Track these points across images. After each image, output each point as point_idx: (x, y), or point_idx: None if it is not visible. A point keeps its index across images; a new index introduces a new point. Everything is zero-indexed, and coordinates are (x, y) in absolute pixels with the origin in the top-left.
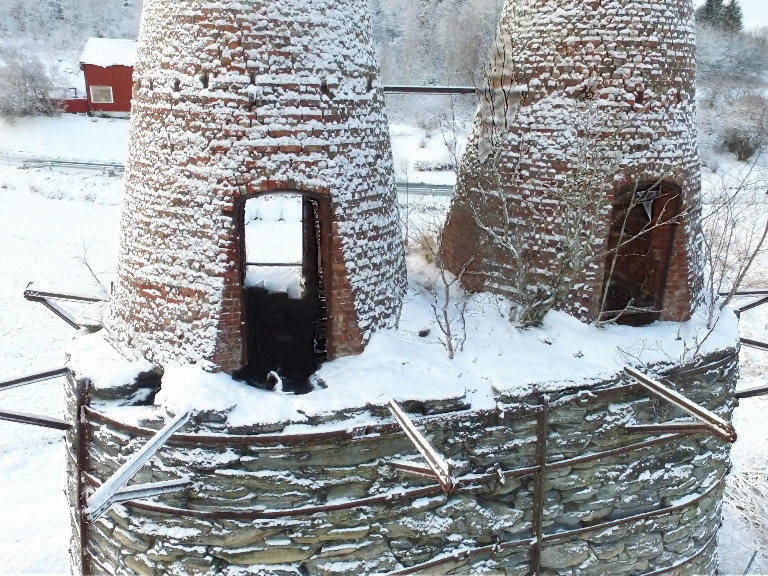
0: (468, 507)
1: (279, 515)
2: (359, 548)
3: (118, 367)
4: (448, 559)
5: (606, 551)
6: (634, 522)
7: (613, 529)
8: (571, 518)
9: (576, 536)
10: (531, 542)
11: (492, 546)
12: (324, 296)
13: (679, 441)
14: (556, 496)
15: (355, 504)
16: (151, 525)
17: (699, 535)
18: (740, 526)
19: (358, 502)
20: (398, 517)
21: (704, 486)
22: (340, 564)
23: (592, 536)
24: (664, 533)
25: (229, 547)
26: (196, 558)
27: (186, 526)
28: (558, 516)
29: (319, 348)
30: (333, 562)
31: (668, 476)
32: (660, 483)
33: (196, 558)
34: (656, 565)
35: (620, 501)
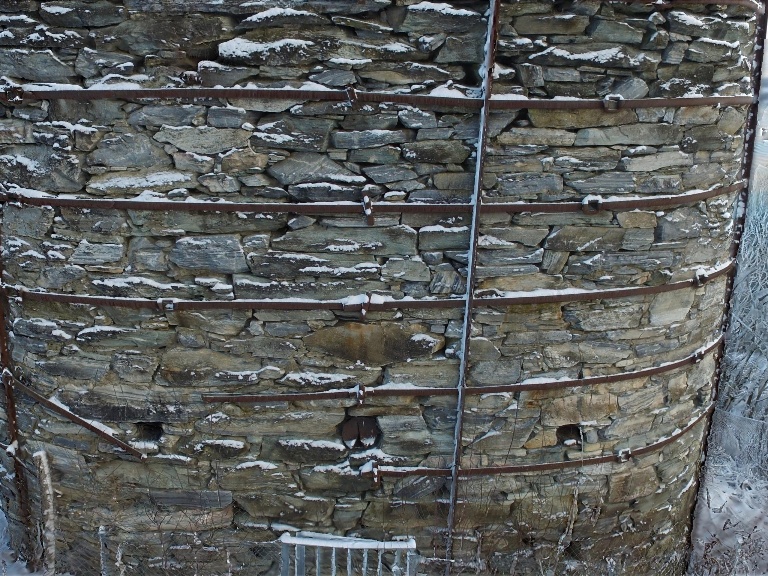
0: None
1: None
2: None
3: None
4: None
5: None
6: None
7: None
8: None
9: None
10: None
11: None
12: None
13: None
14: None
15: None
16: None
17: None
18: None
19: None
20: None
21: None
22: None
23: None
24: None
25: None
26: None
27: None
28: None
29: (476, 77)
30: None
31: None
32: None
33: None
34: None
35: None
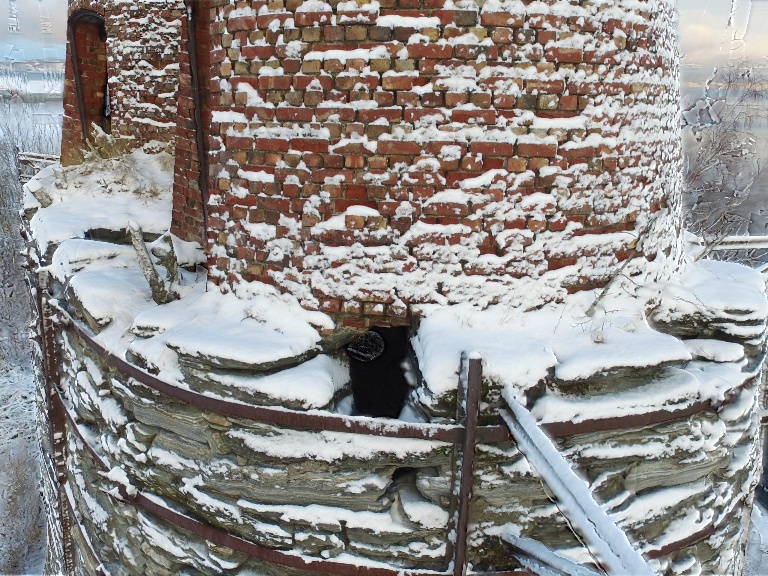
0: None
1: None
2: None
3: (717, 264)
4: None
5: None
6: None
7: None
8: None
9: None
10: None
11: None
12: None
13: None
14: None
15: None
16: None
17: None
18: None
19: None
20: None
21: None
22: None
23: None
24: None
25: None
26: None
27: None
28: None
29: None
30: None
31: None
32: None
33: None
34: None
35: None
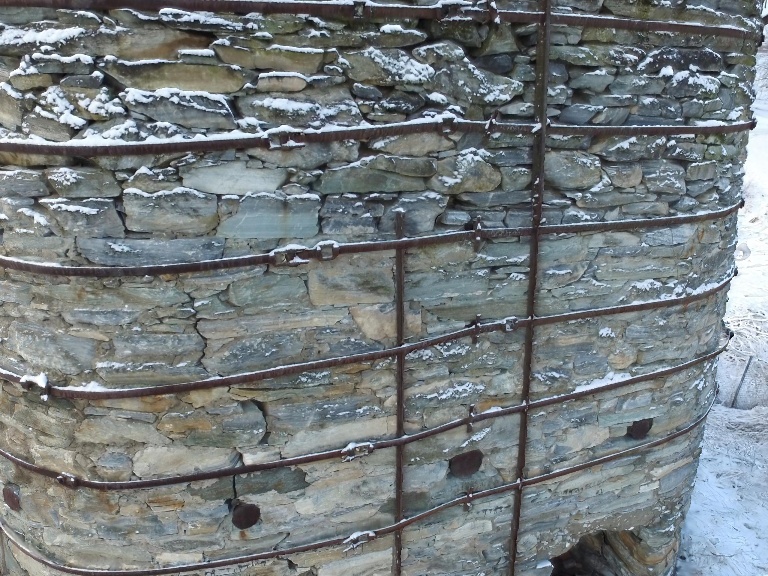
0: (454, 55)
1: (196, 7)
2: (310, 81)
3: None
4: (429, 126)
5: (621, 173)
6: (654, 139)
7: (630, 141)
8: (581, 112)
9: (586, 145)
10: (533, 129)
11: (485, 123)
12: None
13: (704, 44)
14: (563, 72)
15: (303, 8)
16: (13, 31)
17: (724, 188)
18: (726, 365)
19: (307, 5)
20: (362, 49)
21: (731, 118)
22: (285, 100)
23: (605, 149)
24: (687, 166)
25: (127, 60)
26: (80, 76)
27: (63, 26)
28: (565, 106)
29: None
30: (275, 97)
31: (693, 82)
32: (684, 89)
33: (80, 76)
34: (678, 211)
35: (638, 104)
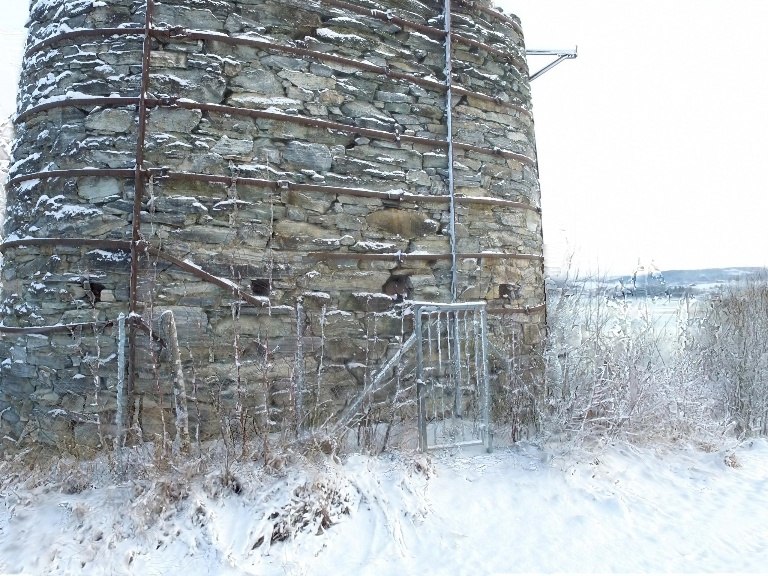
0: None
1: None
2: None
3: None
4: None
5: None
6: None
7: None
8: None
9: None
10: None
11: None
12: (435, 16)
13: None
14: None
15: None
16: None
17: None
18: None
19: None
20: None
21: None
22: None
23: None
24: None
25: None
26: None
27: None
28: None
29: (438, 78)
30: None
31: None
32: None
33: None
34: None
35: None
